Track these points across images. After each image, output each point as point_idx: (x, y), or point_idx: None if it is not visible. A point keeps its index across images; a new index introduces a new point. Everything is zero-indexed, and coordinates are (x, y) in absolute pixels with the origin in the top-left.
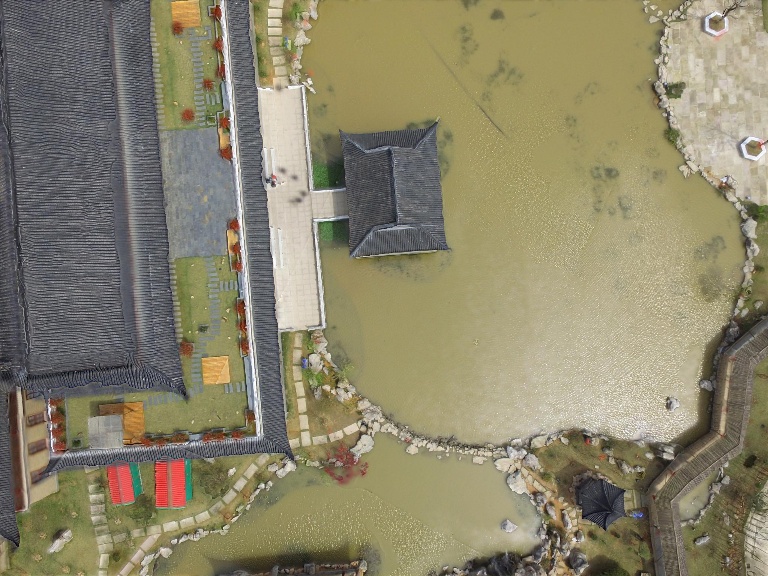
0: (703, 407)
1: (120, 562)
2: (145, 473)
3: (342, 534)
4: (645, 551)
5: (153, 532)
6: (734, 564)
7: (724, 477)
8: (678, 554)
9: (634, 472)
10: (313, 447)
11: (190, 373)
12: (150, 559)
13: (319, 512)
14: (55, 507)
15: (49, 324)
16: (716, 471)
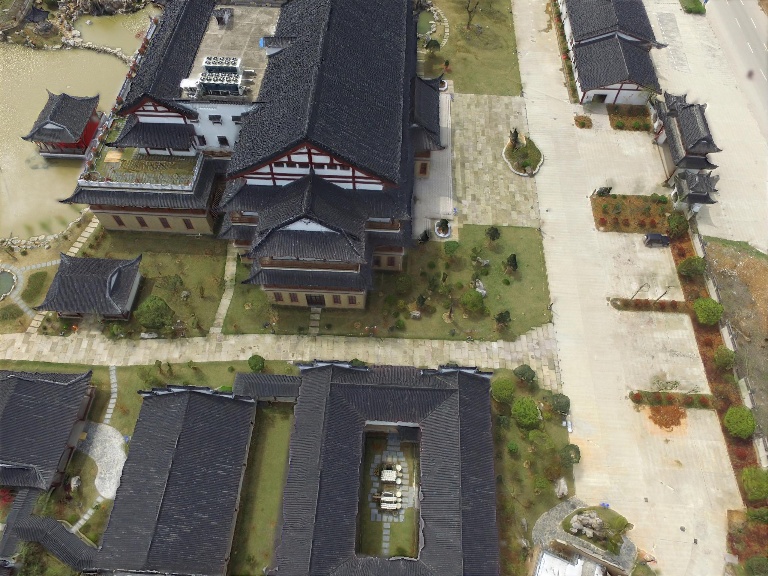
0: None
1: None
2: None
3: None
4: (31, 4)
5: None
6: None
7: None
8: None
9: None
10: None
11: None
12: None
13: None
14: None
15: (183, 1)
16: None
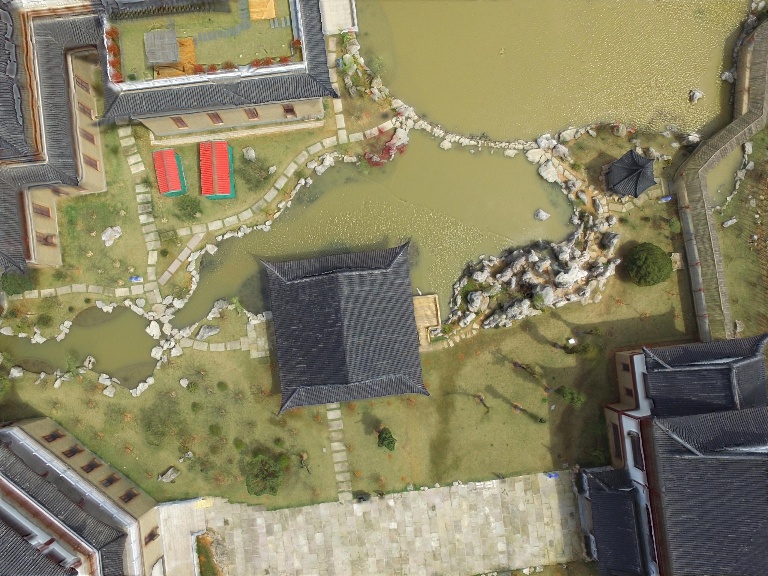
0: (725, 99)
1: (168, 259)
2: (189, 175)
3: (380, 229)
4: (675, 223)
5: (198, 231)
6: (762, 244)
7: (748, 163)
8: (708, 219)
9: (661, 161)
10: (350, 144)
11: (237, 9)
12: (196, 254)
13: (357, 212)
14: (104, 206)
15: None
16: (740, 160)
